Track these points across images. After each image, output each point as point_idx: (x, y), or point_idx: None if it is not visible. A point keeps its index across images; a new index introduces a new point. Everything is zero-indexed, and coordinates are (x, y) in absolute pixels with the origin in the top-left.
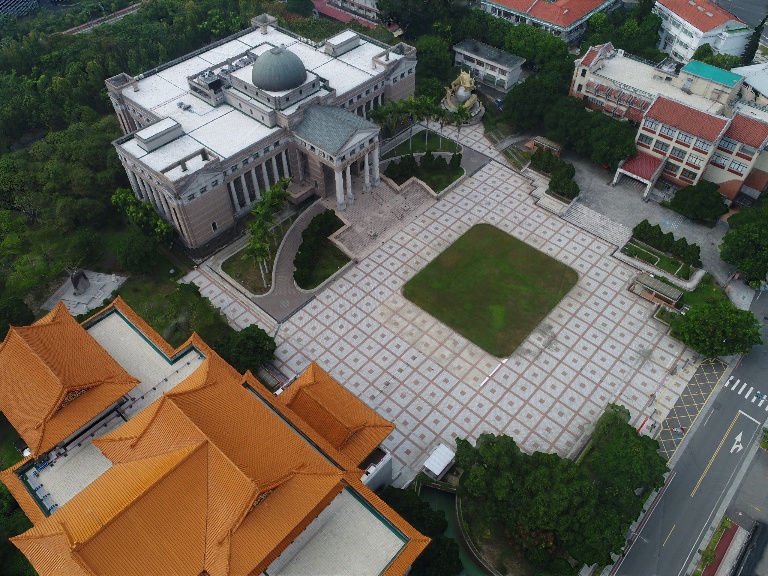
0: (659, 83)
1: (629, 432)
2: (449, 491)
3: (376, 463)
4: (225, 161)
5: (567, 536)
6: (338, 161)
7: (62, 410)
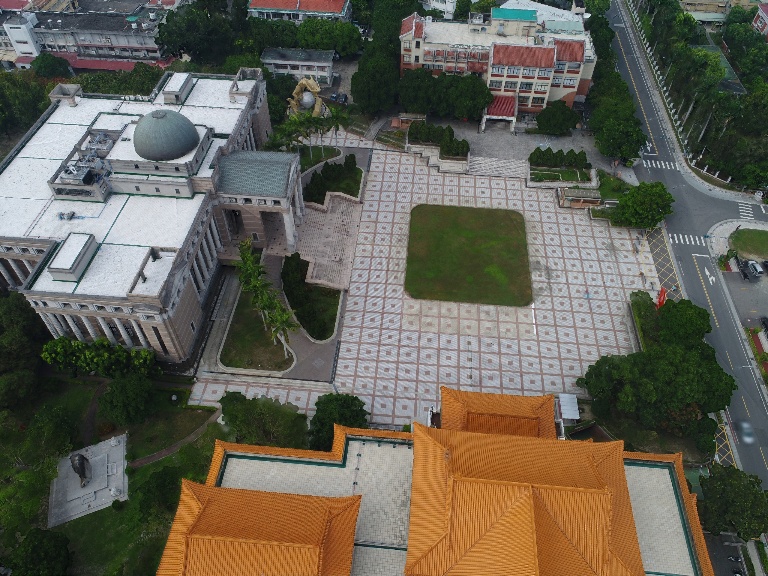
0: (477, 35)
1: (674, 303)
2: (588, 427)
3: (557, 435)
4: (182, 251)
5: (704, 398)
6: (287, 202)
7: (321, 575)
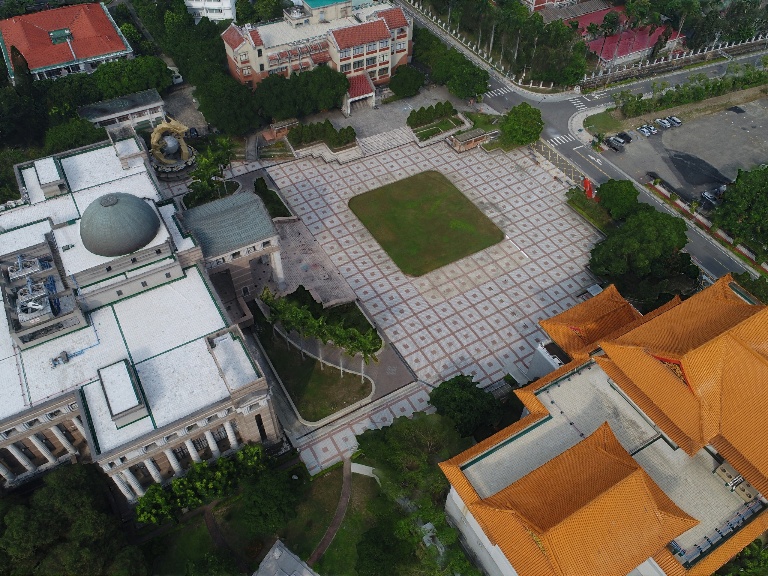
0: (303, 28)
1: (609, 185)
2: None
3: None
4: None
5: None
6: (277, 238)
7: None
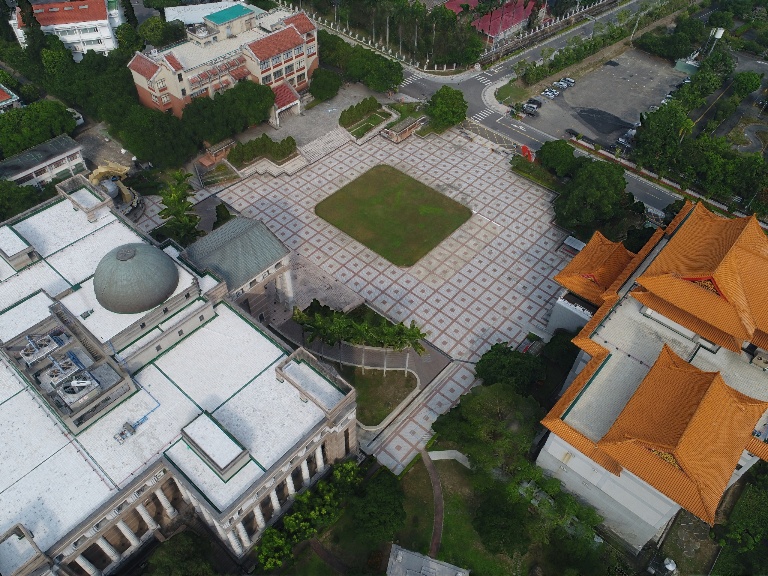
0: (213, 46)
1: (549, 146)
2: None
3: None
4: None
5: None
6: None
7: None
